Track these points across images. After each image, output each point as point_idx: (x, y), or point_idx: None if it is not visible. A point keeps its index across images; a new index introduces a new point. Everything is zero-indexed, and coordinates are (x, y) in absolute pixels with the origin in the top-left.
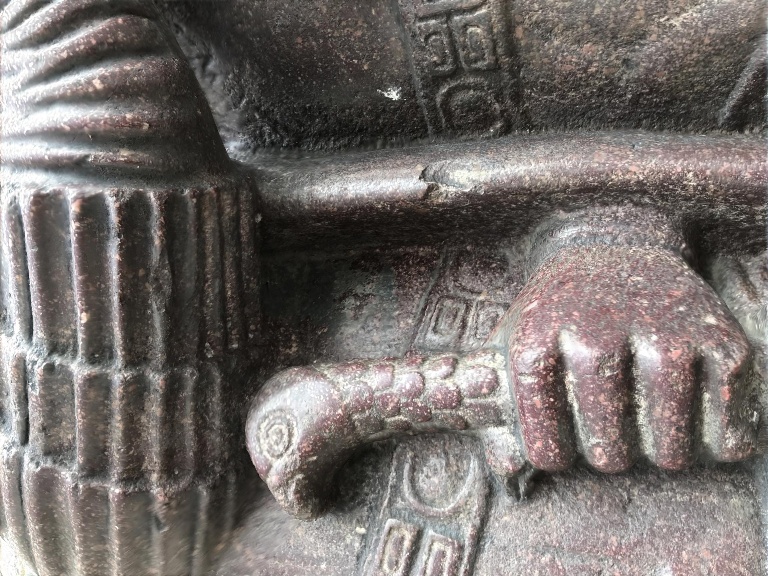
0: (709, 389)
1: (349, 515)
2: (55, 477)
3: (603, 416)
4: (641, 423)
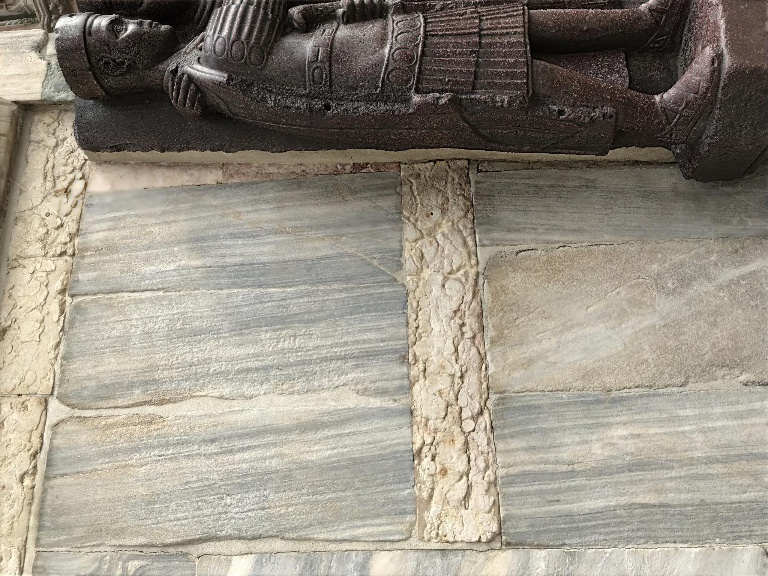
0: None
1: (309, 32)
2: (249, 7)
3: None
4: None
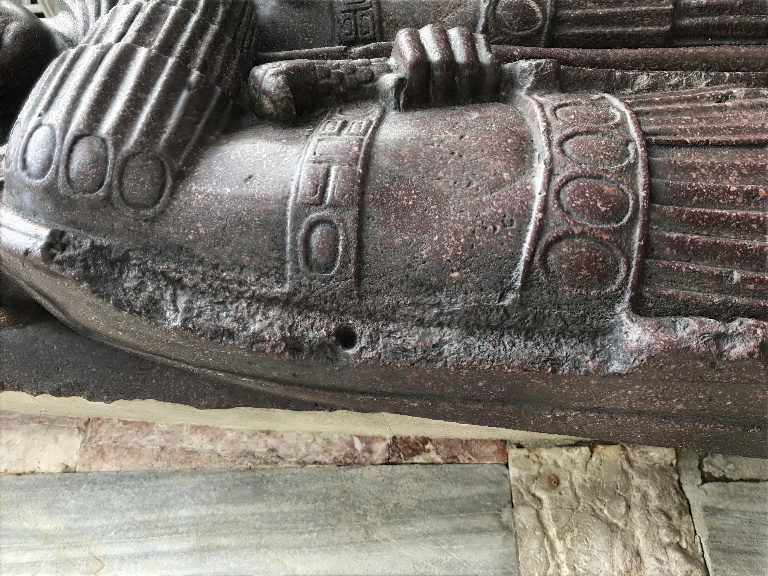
0: (477, 42)
1: None
2: (136, 49)
3: (437, 39)
4: (453, 49)
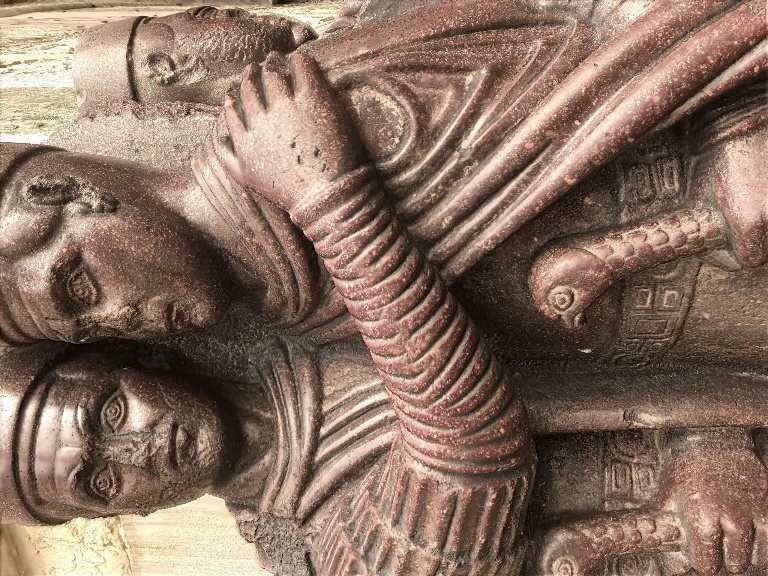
0: None
1: None
2: None
3: (741, 556)
4: (753, 554)
